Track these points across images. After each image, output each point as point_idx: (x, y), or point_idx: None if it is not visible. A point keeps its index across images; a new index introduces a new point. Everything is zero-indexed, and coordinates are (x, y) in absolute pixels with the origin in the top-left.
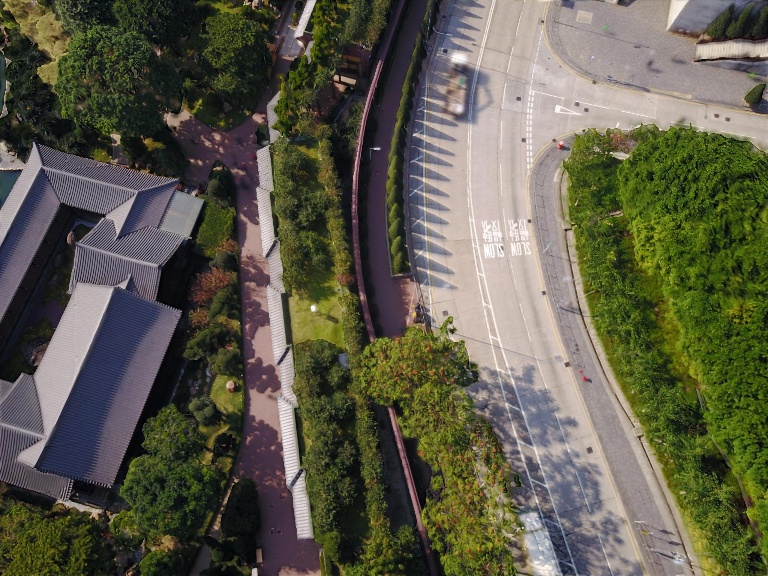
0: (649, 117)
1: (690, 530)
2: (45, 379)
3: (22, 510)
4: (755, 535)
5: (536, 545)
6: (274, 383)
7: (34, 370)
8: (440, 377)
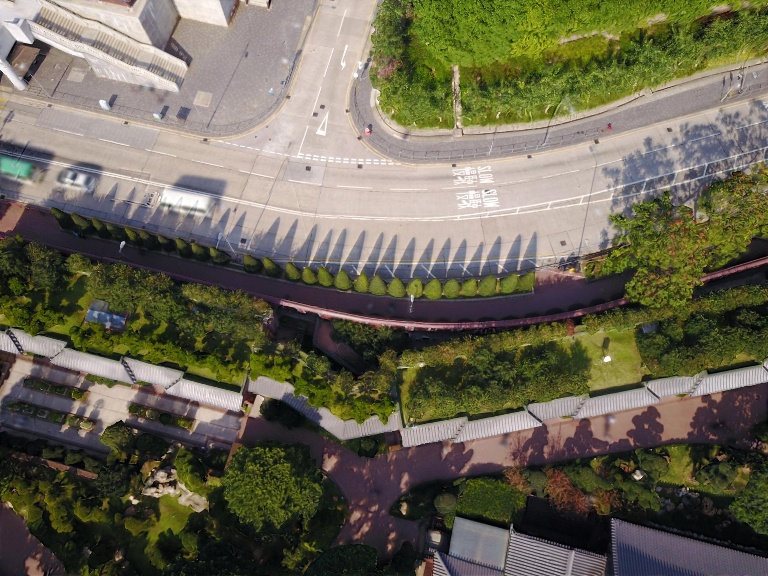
0: (332, 54)
1: (721, 64)
2: None
3: None
4: (749, 8)
5: (756, 175)
6: (651, 415)
7: None
8: None
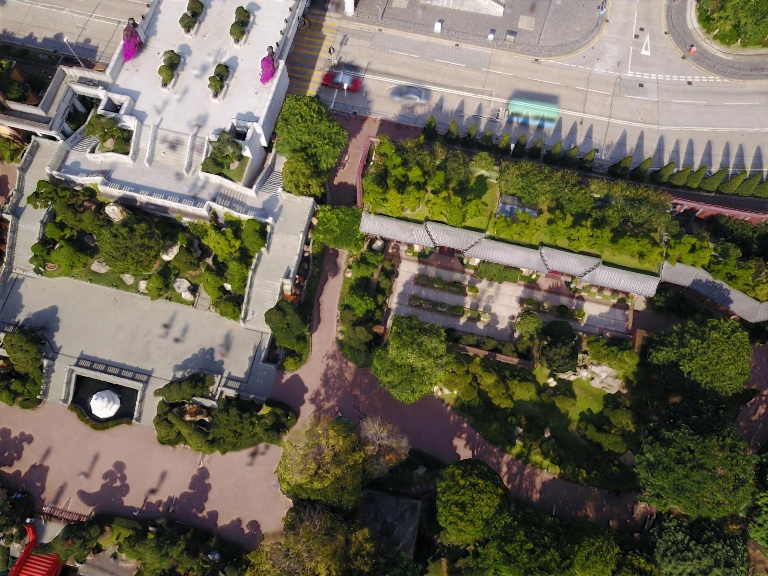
0: None
1: None
2: None
3: None
4: None
5: None
6: None
7: None
8: None
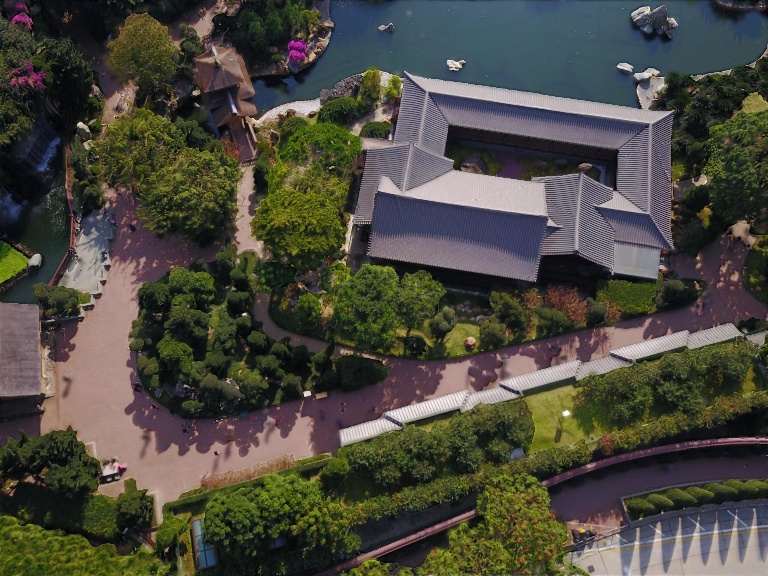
0: None
1: None
2: (452, 179)
3: (343, 191)
4: None
5: None
6: (480, 383)
7: (457, 168)
8: (519, 571)
